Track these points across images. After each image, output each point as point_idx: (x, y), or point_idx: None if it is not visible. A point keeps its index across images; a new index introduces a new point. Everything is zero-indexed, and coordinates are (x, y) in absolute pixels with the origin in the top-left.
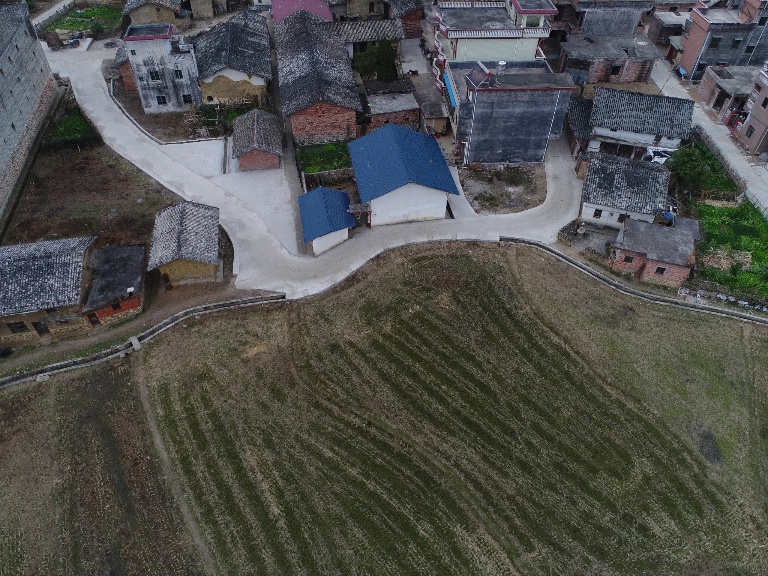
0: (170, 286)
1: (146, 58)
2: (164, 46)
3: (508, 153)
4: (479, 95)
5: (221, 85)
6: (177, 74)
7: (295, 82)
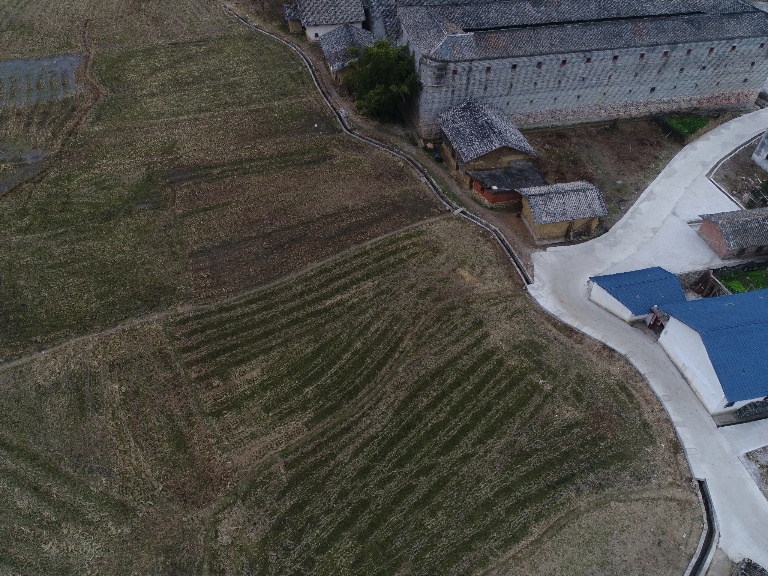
0: (519, 215)
1: None
2: None
3: None
4: None
5: None
6: None
7: None
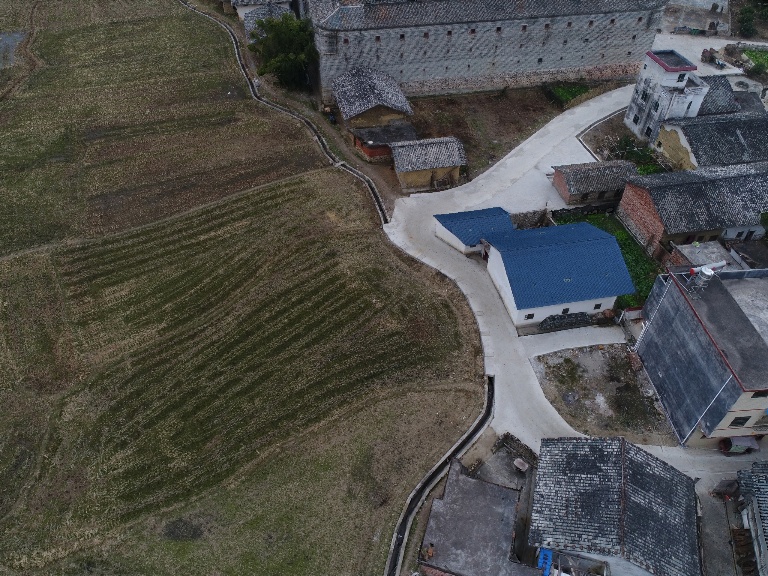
0: (392, 167)
1: (648, 77)
2: (662, 76)
3: (665, 387)
4: (674, 285)
5: (672, 140)
6: (656, 106)
7: (691, 175)
